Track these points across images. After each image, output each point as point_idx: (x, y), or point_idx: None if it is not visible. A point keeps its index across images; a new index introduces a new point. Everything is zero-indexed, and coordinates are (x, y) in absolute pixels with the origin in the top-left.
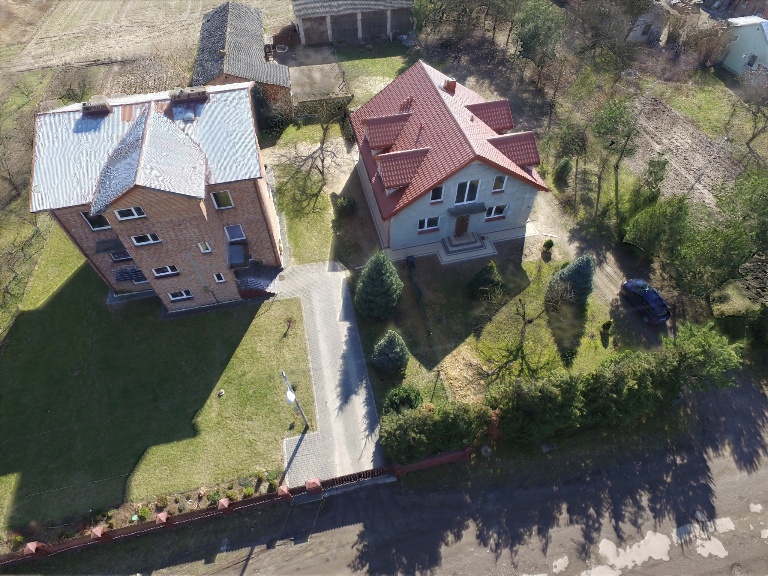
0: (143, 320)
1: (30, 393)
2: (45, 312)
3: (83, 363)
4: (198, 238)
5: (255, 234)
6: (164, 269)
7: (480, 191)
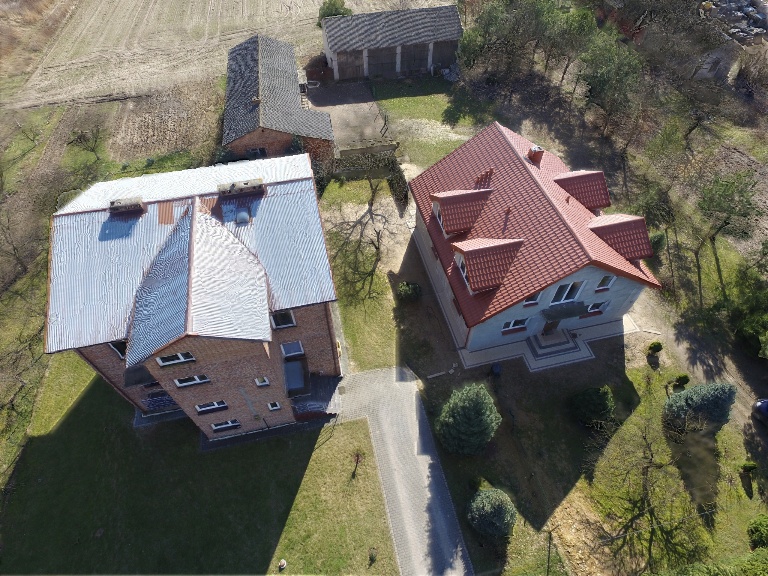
0: (178, 451)
1: (42, 563)
2: (59, 439)
3: (107, 517)
4: (256, 375)
5: (316, 348)
6: (209, 403)
7: (583, 291)
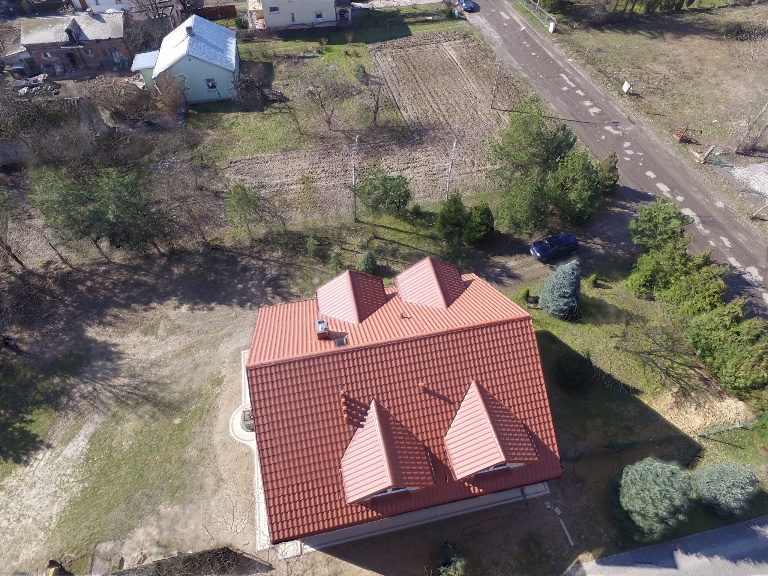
0: None
1: None
2: None
3: None
4: None
5: None
6: None
7: None
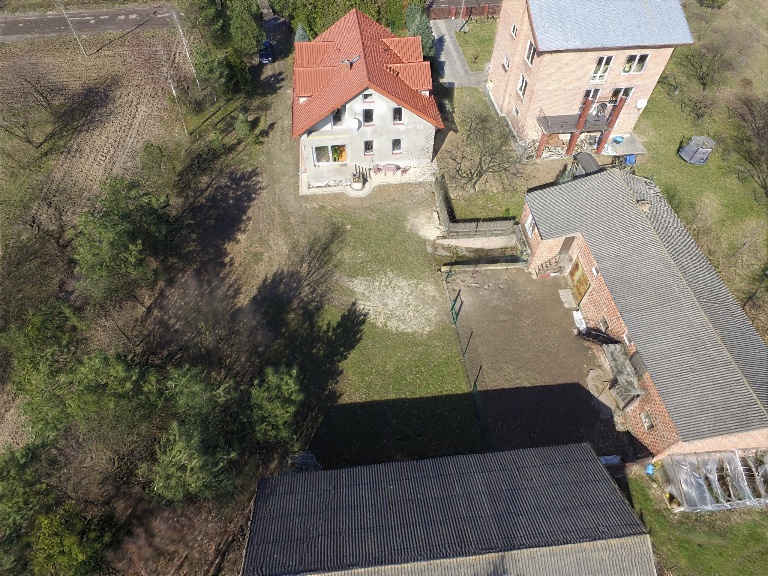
0: None
1: None
2: None
3: None
4: None
5: None
6: None
7: None
